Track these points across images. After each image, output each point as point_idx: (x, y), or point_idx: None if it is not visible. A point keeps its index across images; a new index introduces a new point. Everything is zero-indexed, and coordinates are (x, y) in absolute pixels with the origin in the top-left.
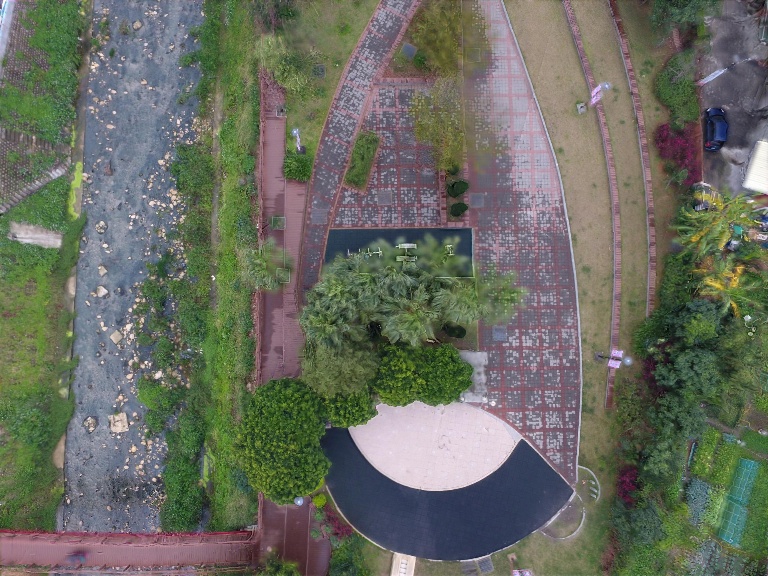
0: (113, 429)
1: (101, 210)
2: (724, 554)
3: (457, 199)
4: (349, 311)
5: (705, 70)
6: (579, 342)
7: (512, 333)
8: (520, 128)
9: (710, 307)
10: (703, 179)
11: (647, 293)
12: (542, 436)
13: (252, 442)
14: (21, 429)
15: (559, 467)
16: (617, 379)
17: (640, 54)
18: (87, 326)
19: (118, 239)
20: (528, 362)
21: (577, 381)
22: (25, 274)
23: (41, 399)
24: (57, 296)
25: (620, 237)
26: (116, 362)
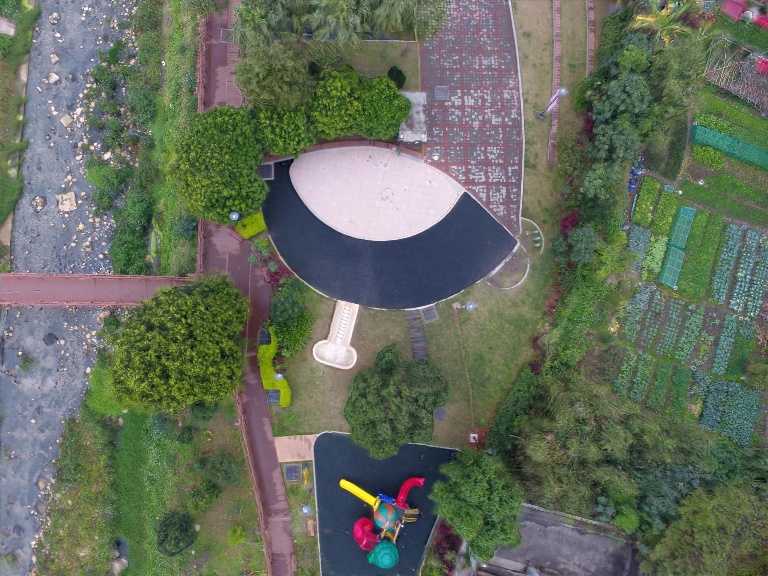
0: (61, 207)
1: (55, 3)
2: (670, 302)
3: None
4: (278, 4)
5: None
6: (521, 102)
7: (454, 93)
8: None
9: (641, 37)
10: None
11: (586, 56)
12: (485, 190)
13: (187, 156)
14: None
15: (502, 219)
16: (559, 136)
17: None
18: (38, 111)
19: (71, 29)
20: (470, 120)
21: (519, 139)
22: None
23: None
24: (8, 81)
25: (559, 4)
26: (66, 145)
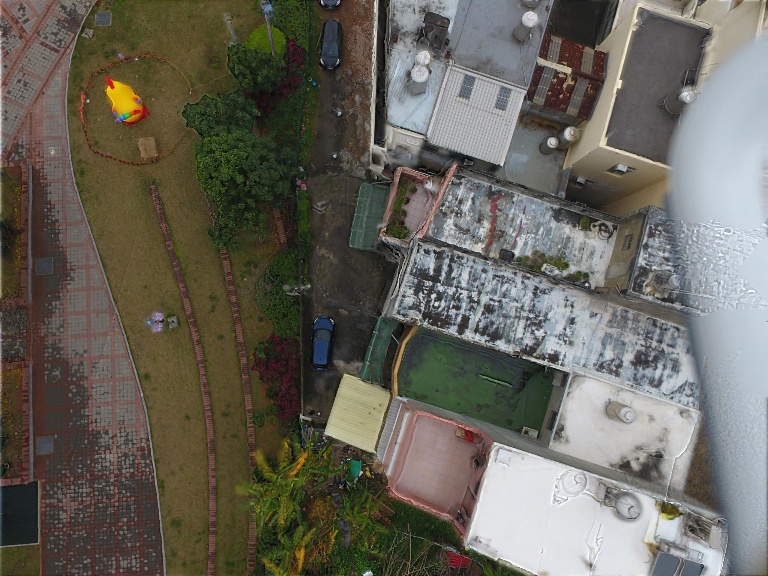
0: None
1: None
2: None
3: (15, 449)
4: None
5: (318, 268)
6: None
7: None
8: (99, 352)
9: None
10: (302, 411)
11: (248, 550)
12: None
13: None
14: None
15: None
16: None
17: (241, 253)
18: None
19: None
20: None
21: None
22: None
23: None
24: None
25: (215, 482)
26: None
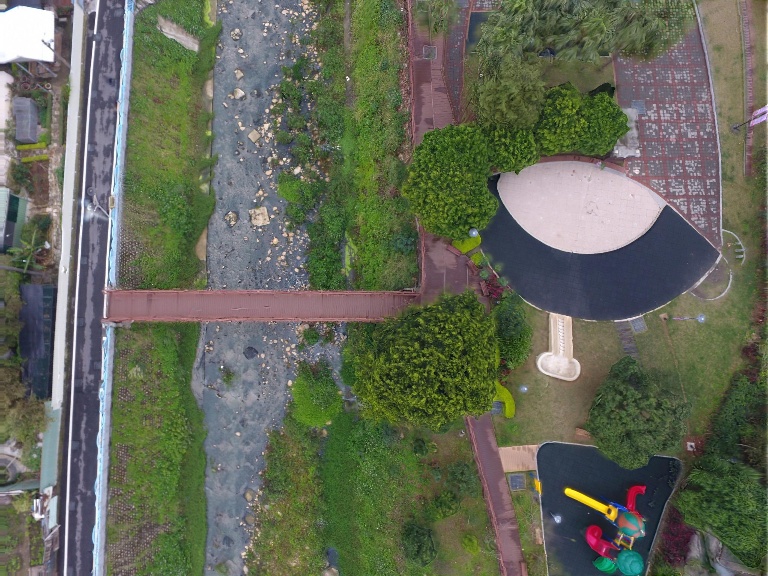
0: (254, 222)
1: (235, 19)
2: None
3: None
4: (531, 25)
5: None
6: (714, 116)
7: (650, 107)
8: None
9: None
10: None
11: None
12: (686, 202)
13: (428, 174)
14: (169, 214)
15: (704, 231)
16: (754, 149)
17: None
18: (225, 127)
19: (253, 45)
20: (667, 134)
21: (715, 152)
22: (171, 66)
23: (185, 190)
24: (196, 97)
25: (747, 19)
26: (254, 160)
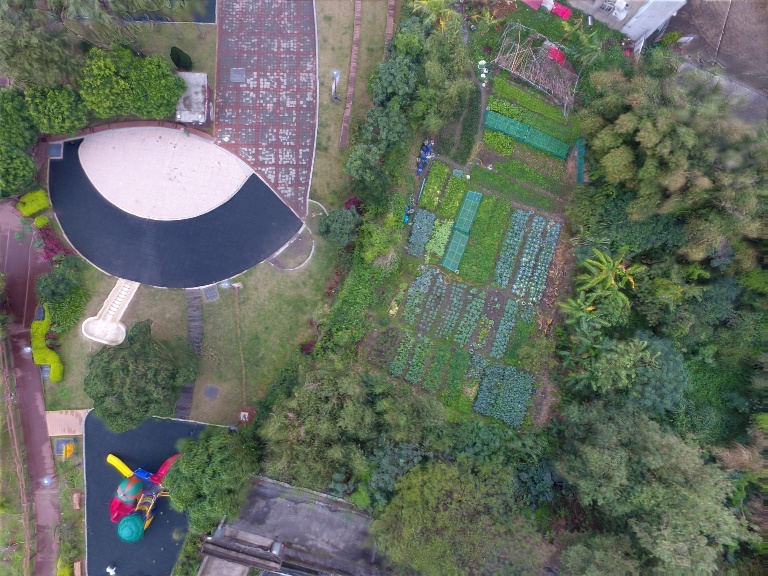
0: None
1: None
2: (452, 286)
3: None
4: None
5: None
6: (316, 85)
7: (250, 75)
8: None
9: (414, 19)
10: None
11: (385, 40)
12: (274, 171)
13: None
14: None
15: (289, 200)
16: None
17: None
18: None
19: None
20: (264, 102)
21: (313, 121)
22: None
23: None
24: None
25: None
26: None
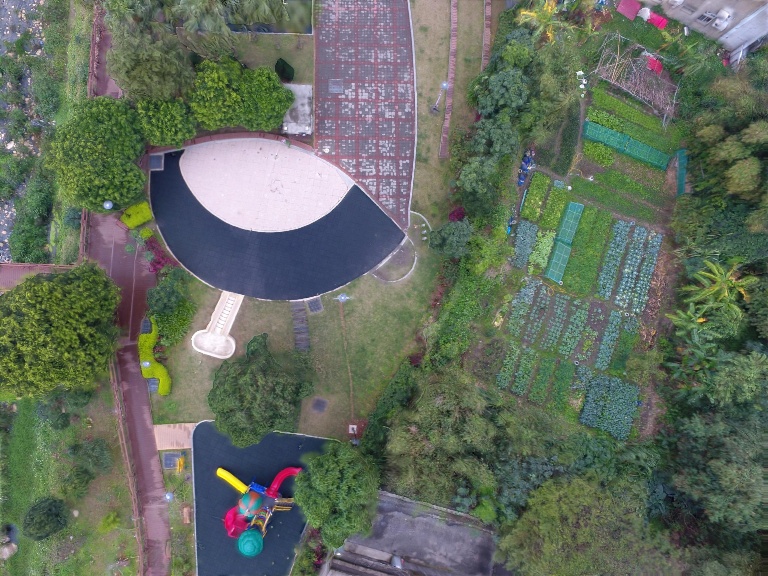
0: None
1: None
2: (555, 297)
3: None
4: None
5: None
6: (415, 96)
7: (348, 86)
8: None
9: (523, 31)
10: None
11: (482, 50)
12: (375, 183)
13: (62, 145)
14: None
15: (391, 212)
16: (451, 130)
17: None
18: None
19: None
20: (363, 113)
21: (412, 132)
22: None
23: None
24: None
25: None
26: None
